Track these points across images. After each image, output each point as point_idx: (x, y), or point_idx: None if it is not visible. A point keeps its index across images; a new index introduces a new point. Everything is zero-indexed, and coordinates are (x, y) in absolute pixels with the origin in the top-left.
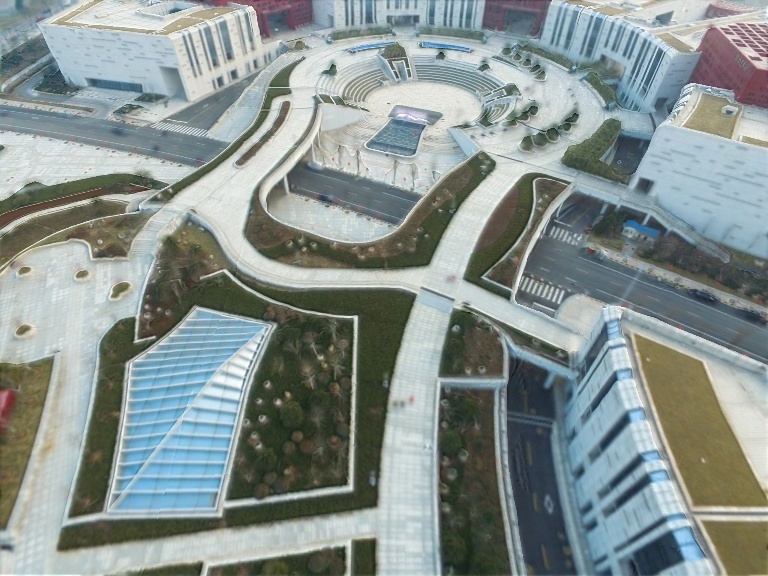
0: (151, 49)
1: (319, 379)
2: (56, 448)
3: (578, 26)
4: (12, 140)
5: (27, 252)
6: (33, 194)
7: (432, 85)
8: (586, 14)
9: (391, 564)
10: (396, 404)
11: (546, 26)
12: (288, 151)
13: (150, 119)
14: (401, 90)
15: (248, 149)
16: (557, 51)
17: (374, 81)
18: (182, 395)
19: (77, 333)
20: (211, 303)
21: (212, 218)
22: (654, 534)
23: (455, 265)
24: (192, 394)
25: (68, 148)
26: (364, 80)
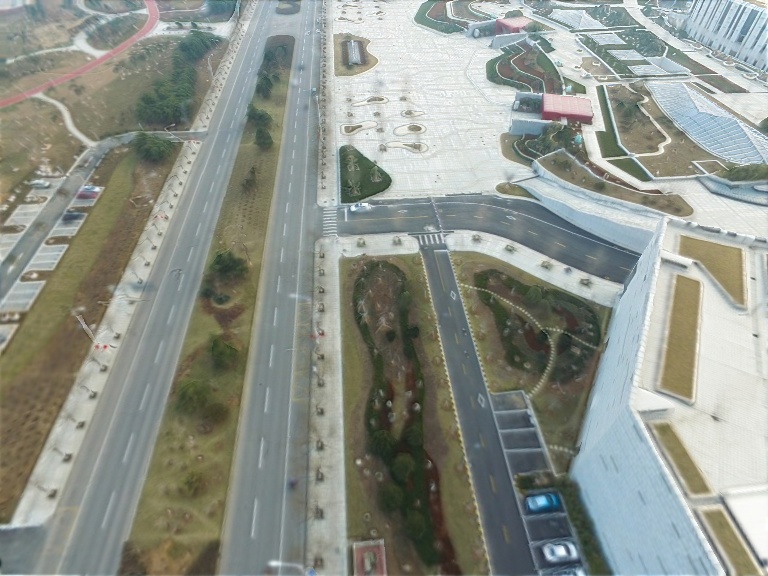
0: None
1: None
2: (548, 25)
3: None
4: None
5: None
6: None
7: None
8: None
9: (657, 33)
10: None
11: None
12: None
13: None
14: None
15: None
16: None
17: None
18: (577, 15)
19: None
20: (558, 8)
21: None
22: (725, 8)
23: None
24: None
25: None
26: None
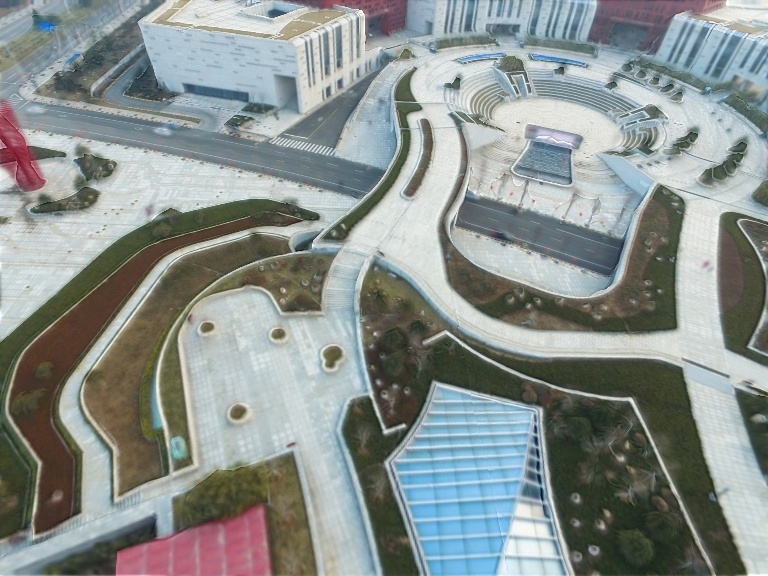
0: (269, 55)
1: (637, 491)
2: None
3: (707, 43)
4: (122, 155)
5: (201, 302)
6: (172, 223)
7: (554, 102)
8: (719, 31)
9: None
10: (738, 526)
11: (665, 42)
12: (456, 180)
13: (266, 133)
14: (524, 107)
15: (410, 176)
16: (675, 69)
17: (494, 96)
18: (486, 516)
19: (303, 416)
20: (452, 378)
21: (404, 263)
22: None
23: (707, 330)
24: (501, 516)
25: (188, 166)
26: (485, 95)
